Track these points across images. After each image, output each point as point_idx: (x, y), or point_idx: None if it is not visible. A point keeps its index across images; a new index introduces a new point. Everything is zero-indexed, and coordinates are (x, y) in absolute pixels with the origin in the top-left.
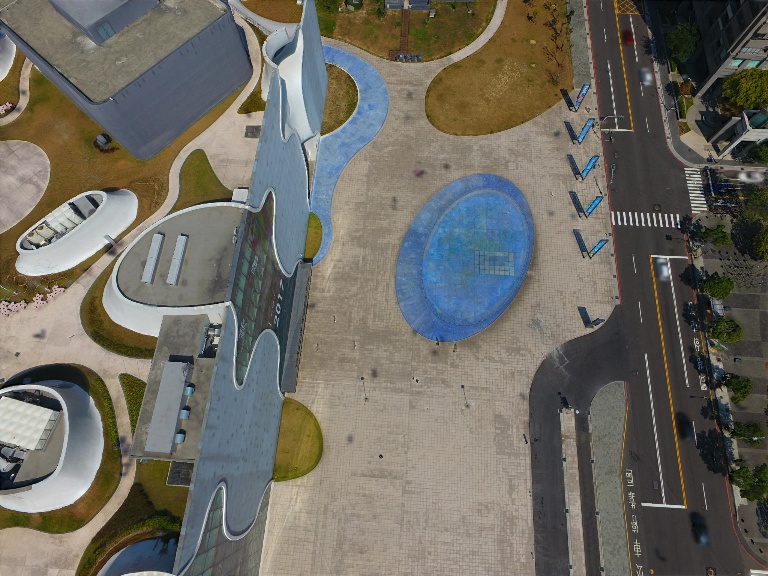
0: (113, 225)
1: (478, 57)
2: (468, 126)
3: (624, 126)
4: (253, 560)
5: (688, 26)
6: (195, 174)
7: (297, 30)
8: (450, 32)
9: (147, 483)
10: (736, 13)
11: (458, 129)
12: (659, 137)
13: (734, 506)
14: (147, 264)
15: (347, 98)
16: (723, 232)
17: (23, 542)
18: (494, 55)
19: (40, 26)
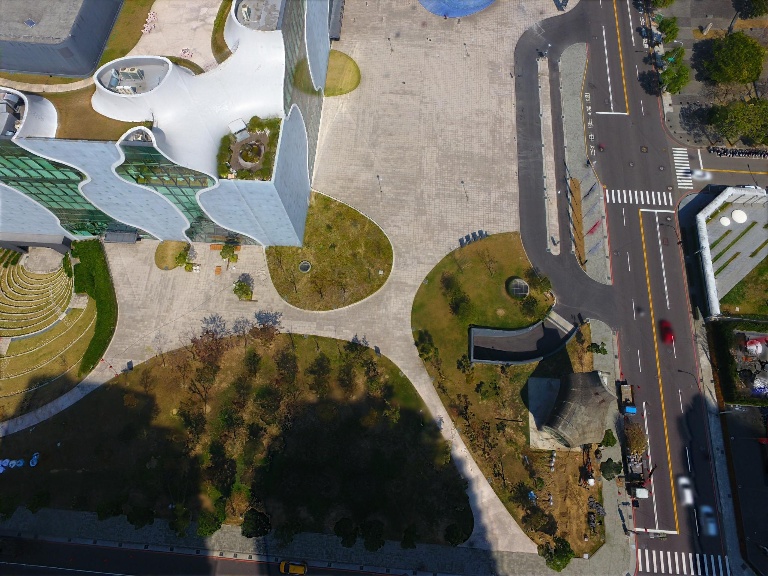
0: None
1: None
2: None
3: None
4: (312, 139)
5: None
6: None
7: None
8: None
9: None
10: None
11: None
12: None
13: (663, 113)
14: None
15: None
16: None
17: None
18: None
19: None
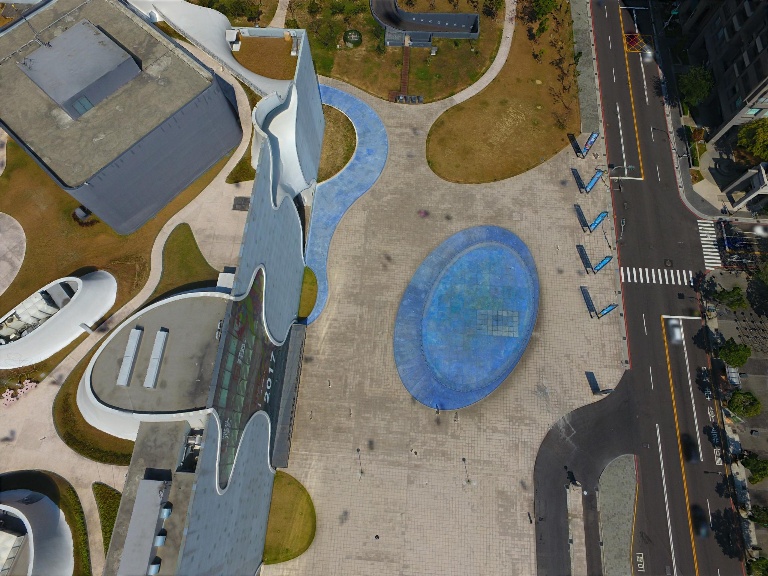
0: (90, 312)
1: (481, 98)
2: (471, 173)
3: (634, 174)
4: None
5: (702, 70)
6: (179, 252)
7: (290, 86)
8: (452, 71)
9: None
10: (753, 61)
11: (460, 176)
12: (671, 186)
13: None
14: (123, 364)
15: (345, 142)
16: (739, 294)
17: None
18: (498, 96)
19: (13, 97)
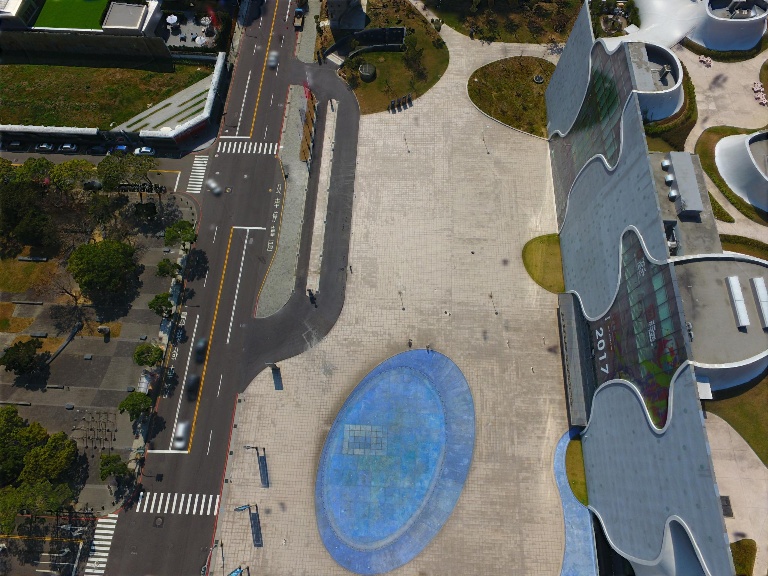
0: None
1: None
2: None
3: None
4: None
5: None
6: (766, 436)
7: None
8: None
9: None
10: None
11: None
12: None
13: (195, 229)
14: (766, 294)
15: None
16: None
17: (743, 121)
18: None
19: None
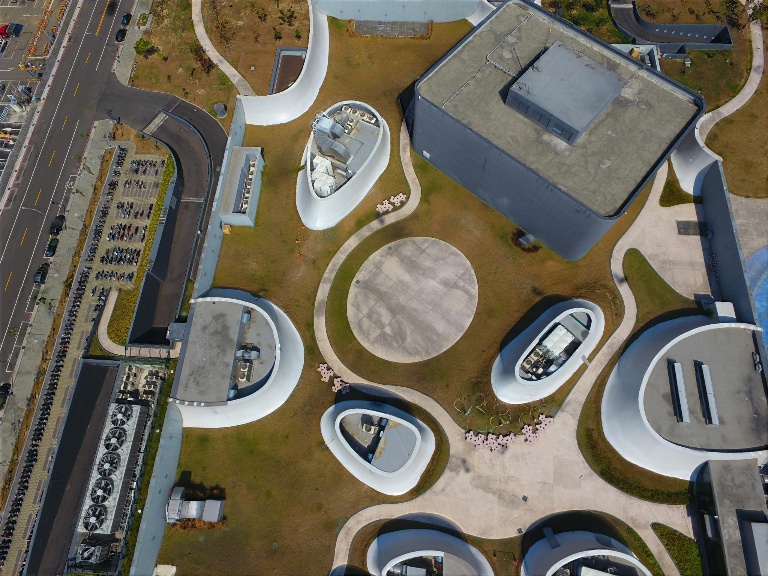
0: (589, 344)
1: (748, 111)
2: (759, 187)
3: None
4: None
5: None
6: (641, 278)
7: None
8: (712, 83)
9: None
10: None
11: (749, 191)
12: None
13: None
14: (681, 400)
15: None
16: None
17: None
18: (765, 108)
19: (495, 122)
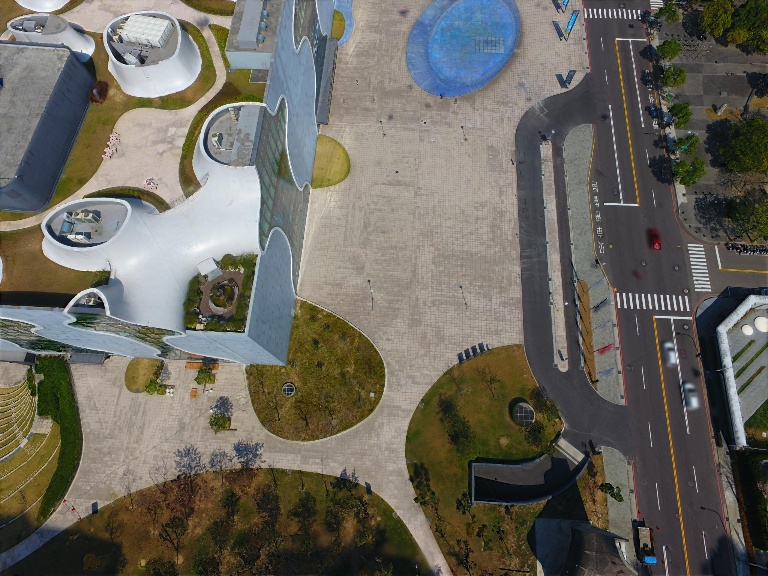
0: None
1: None
2: None
3: None
4: (298, 238)
5: None
6: None
7: None
8: None
9: (235, 82)
10: None
11: None
12: None
13: (677, 204)
14: None
15: None
16: (673, 11)
17: (149, 115)
18: None
19: None
